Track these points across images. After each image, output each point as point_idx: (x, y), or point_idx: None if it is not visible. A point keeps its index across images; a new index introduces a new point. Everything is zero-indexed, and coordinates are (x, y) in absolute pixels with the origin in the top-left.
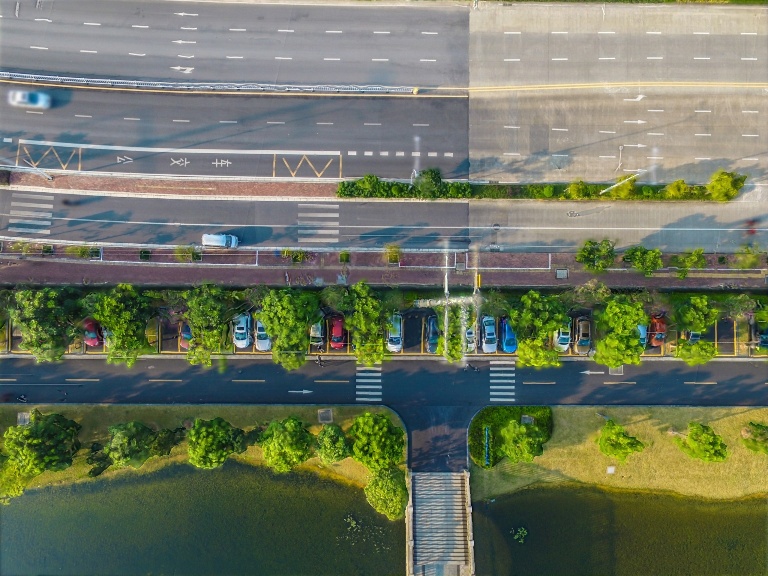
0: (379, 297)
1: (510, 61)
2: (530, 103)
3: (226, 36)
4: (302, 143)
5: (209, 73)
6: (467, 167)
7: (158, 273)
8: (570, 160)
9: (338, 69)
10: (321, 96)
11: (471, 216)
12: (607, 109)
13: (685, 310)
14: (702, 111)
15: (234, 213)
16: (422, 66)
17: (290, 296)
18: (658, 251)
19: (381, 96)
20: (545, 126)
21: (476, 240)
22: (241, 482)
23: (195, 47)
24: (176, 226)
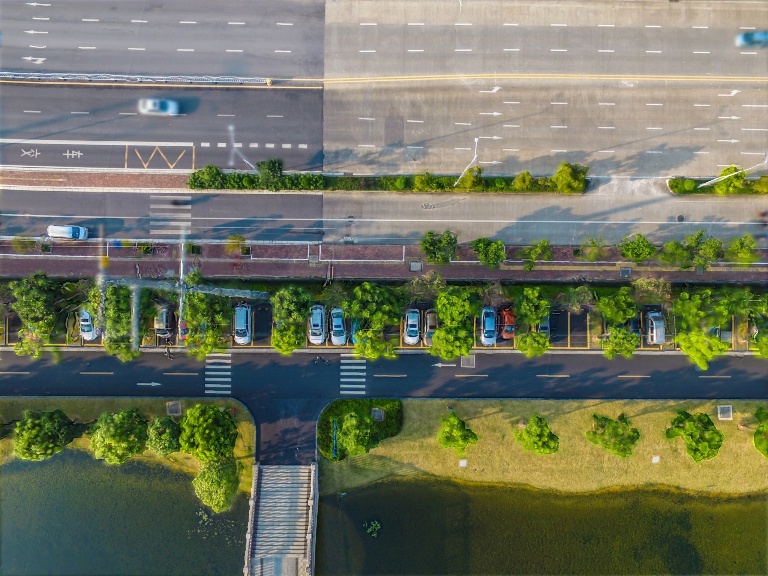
0: (211, 288)
1: (366, 52)
2: (385, 95)
3: (79, 26)
4: (154, 134)
5: (61, 64)
6: (321, 159)
7: (7, 265)
8: (425, 152)
9: (192, 60)
10: (174, 87)
11: (325, 208)
12: (463, 101)
13: (520, 302)
14: (559, 103)
15: (85, 204)
16: (277, 57)
17: (116, 287)
18: (500, 243)
19: (235, 87)
20: (400, 118)
21: (330, 232)
22: (92, 475)
23: (47, 37)
24: (26, 217)
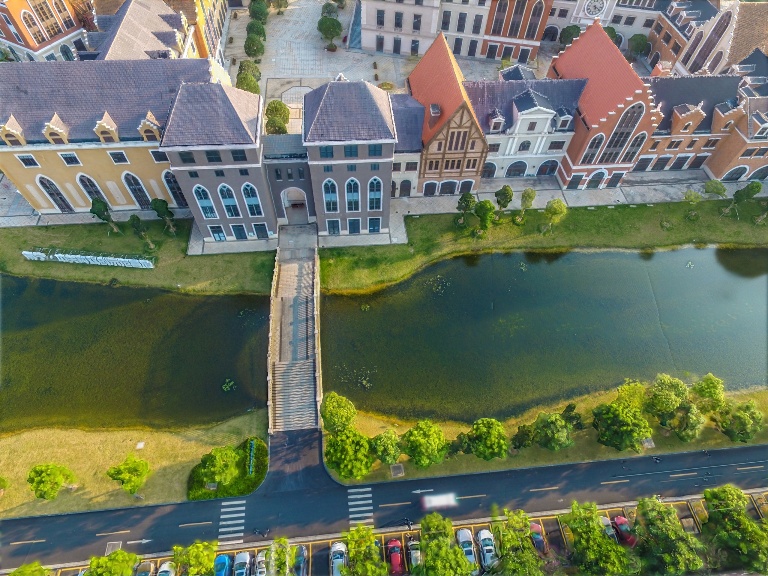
0: None
1: None
2: None
3: None
4: None
5: None
6: None
7: None
8: None
9: None
10: None
11: None
12: None
13: None
14: None
15: None
16: None
17: None
18: None
19: None
20: None
21: None
22: (459, 407)
23: None
24: None
